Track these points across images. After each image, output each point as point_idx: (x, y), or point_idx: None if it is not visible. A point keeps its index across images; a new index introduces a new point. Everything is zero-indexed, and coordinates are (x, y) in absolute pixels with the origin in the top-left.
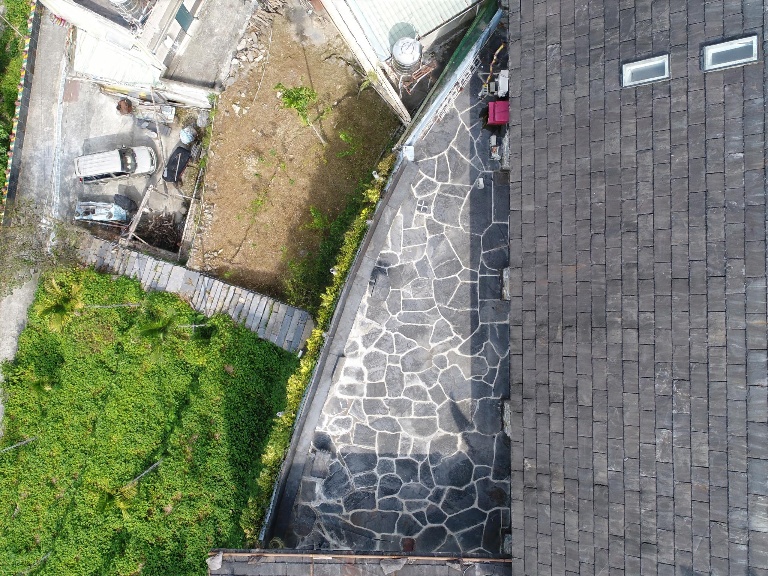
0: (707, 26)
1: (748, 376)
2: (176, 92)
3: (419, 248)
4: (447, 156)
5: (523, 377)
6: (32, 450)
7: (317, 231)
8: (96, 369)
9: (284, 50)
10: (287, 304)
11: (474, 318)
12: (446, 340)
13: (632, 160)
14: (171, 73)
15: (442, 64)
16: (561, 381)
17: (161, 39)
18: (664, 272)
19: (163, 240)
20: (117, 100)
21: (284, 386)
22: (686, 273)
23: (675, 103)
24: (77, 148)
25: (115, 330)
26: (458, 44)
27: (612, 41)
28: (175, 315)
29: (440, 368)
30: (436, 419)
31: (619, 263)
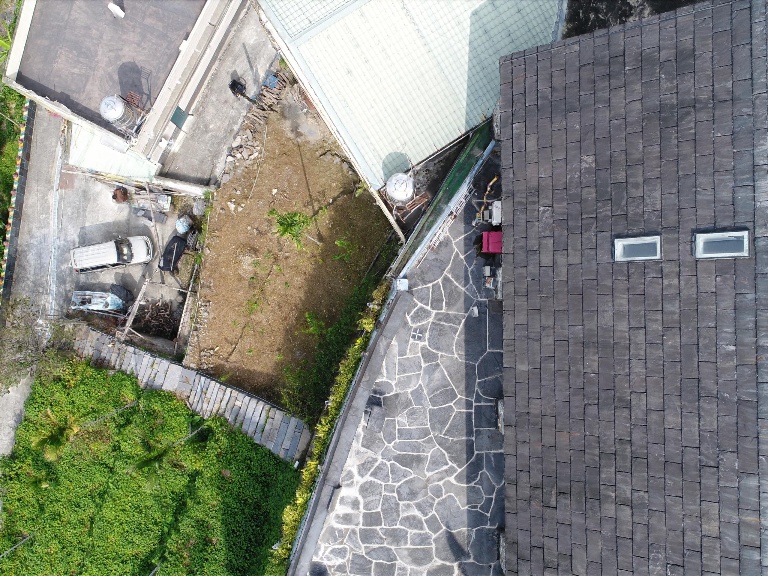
0: (698, 213)
1: (742, 572)
2: (171, 187)
3: (414, 376)
4: (441, 284)
5: (518, 537)
6: (30, 545)
7: (313, 336)
8: (93, 466)
9: (279, 147)
10: (283, 409)
11: (469, 447)
12: (442, 469)
13: (625, 335)
14: (166, 170)
15: (436, 181)
16: (555, 547)
17: (156, 144)
18: (657, 454)
19: (160, 328)
20: (113, 188)
21: (281, 494)
22: (679, 458)
23: (667, 285)
24: (73, 236)
25: (112, 426)
26: (452, 162)
27: (604, 213)
28: (170, 446)
29: (436, 497)
30: (432, 548)
31: (612, 437)
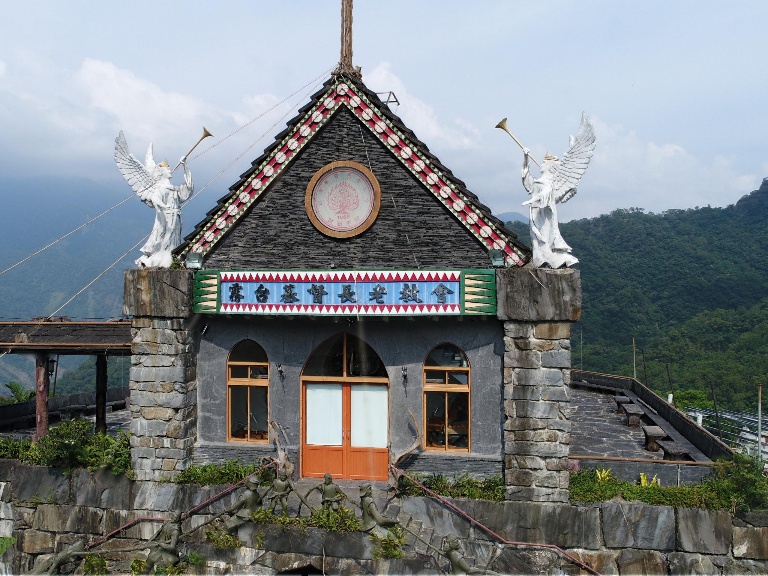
0: None
1: None
2: None
3: None
4: None
5: None
6: None
7: None
8: None
9: None
10: None
11: None
12: None
13: None
14: None
15: None
16: None
17: None
18: None
19: None
20: None
21: None
22: None
23: None
24: None
25: None
26: None
27: None
28: None
29: None
30: None
31: None
